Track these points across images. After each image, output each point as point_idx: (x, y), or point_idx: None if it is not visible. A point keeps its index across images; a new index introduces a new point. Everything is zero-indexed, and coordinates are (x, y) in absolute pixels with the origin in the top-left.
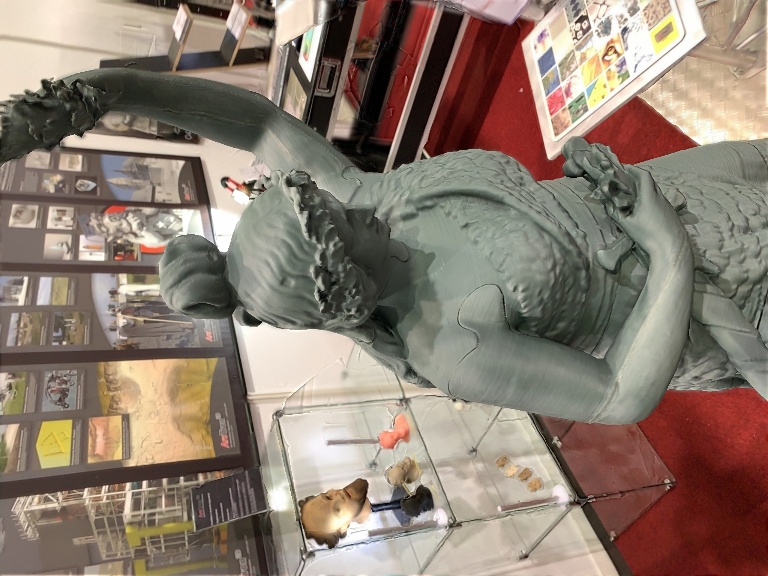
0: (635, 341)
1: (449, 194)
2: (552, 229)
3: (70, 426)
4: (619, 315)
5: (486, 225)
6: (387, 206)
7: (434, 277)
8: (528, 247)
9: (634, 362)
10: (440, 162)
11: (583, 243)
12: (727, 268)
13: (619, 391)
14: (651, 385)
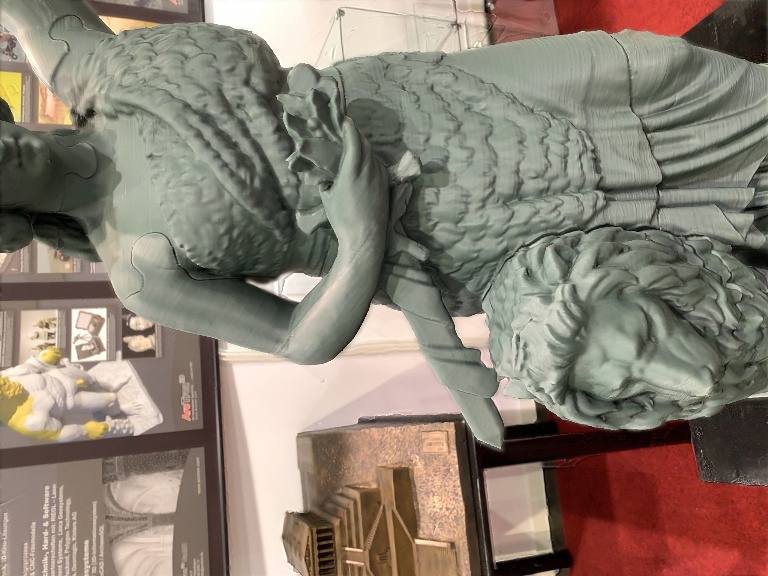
0: (310, 311)
1: (141, 108)
2: (232, 191)
3: (19, 80)
4: (332, 263)
5: (166, 166)
6: (90, 93)
7: (115, 203)
8: (198, 208)
9: (304, 329)
10: (154, 49)
11: (292, 194)
12: (456, 244)
13: (288, 347)
14: (315, 352)
